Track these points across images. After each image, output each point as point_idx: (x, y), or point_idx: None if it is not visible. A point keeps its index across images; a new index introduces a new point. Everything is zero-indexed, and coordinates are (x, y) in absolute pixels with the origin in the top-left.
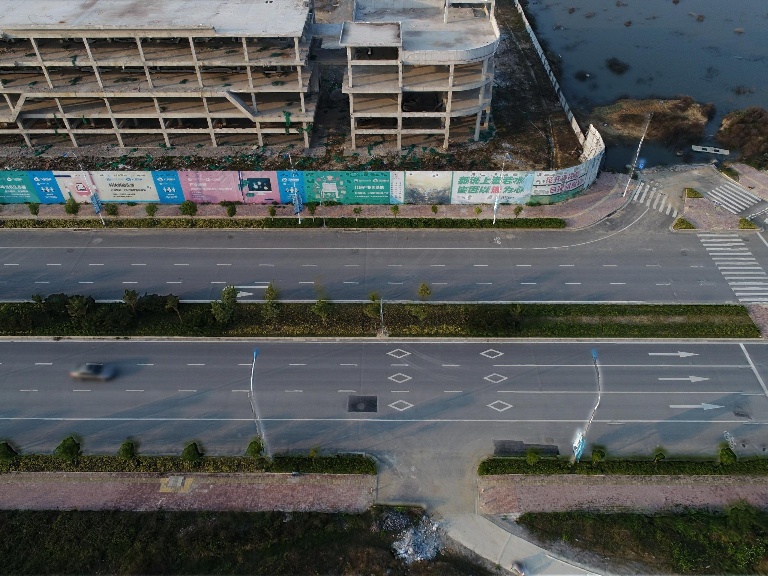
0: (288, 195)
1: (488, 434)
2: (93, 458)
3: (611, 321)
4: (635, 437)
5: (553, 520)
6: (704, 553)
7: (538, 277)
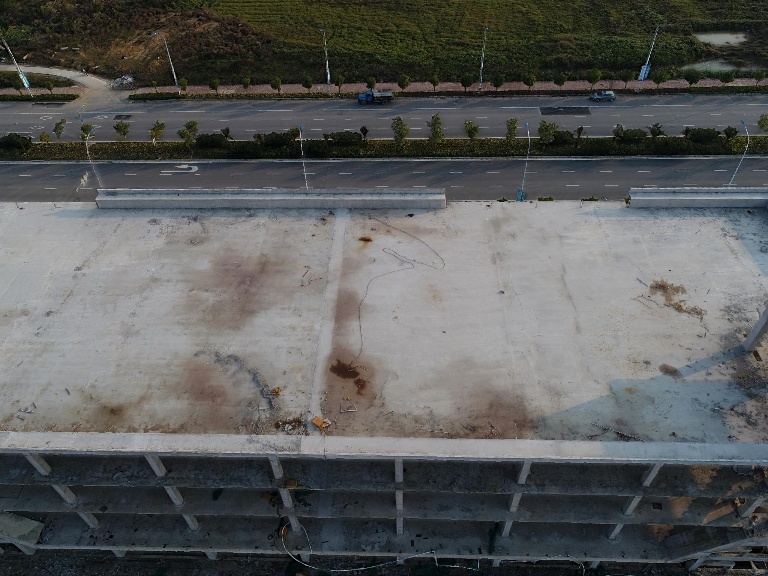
0: None
1: (62, 109)
2: (270, 96)
3: None
4: None
5: (58, 85)
6: (5, 77)
7: None
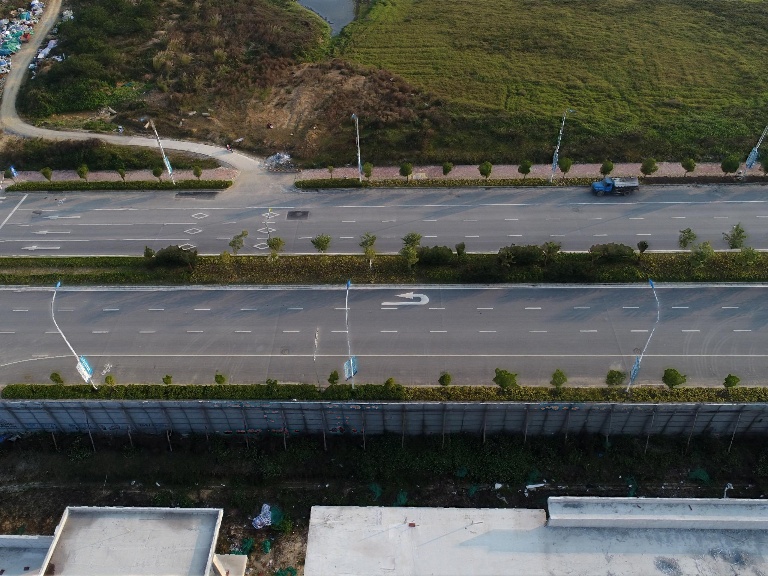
0: (372, 426)
1: (216, 202)
2: (475, 184)
3: (65, 271)
4: (121, 202)
5: (200, 166)
6: None
7: (96, 317)
